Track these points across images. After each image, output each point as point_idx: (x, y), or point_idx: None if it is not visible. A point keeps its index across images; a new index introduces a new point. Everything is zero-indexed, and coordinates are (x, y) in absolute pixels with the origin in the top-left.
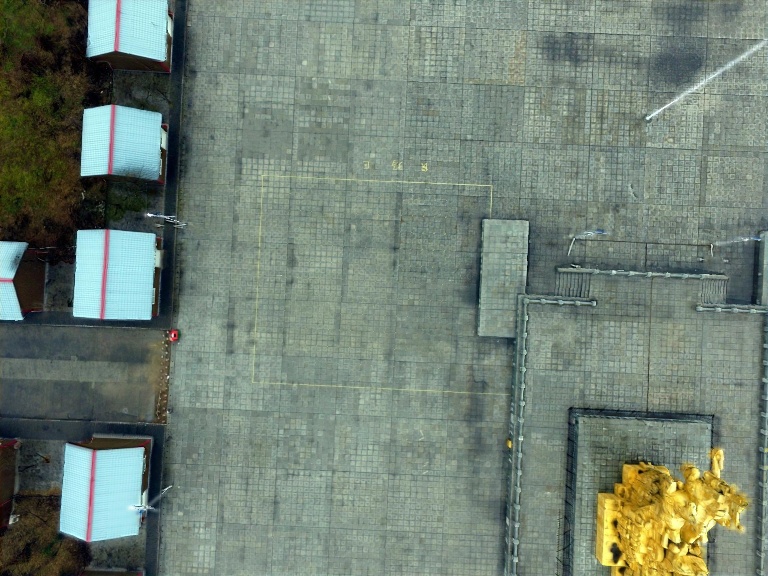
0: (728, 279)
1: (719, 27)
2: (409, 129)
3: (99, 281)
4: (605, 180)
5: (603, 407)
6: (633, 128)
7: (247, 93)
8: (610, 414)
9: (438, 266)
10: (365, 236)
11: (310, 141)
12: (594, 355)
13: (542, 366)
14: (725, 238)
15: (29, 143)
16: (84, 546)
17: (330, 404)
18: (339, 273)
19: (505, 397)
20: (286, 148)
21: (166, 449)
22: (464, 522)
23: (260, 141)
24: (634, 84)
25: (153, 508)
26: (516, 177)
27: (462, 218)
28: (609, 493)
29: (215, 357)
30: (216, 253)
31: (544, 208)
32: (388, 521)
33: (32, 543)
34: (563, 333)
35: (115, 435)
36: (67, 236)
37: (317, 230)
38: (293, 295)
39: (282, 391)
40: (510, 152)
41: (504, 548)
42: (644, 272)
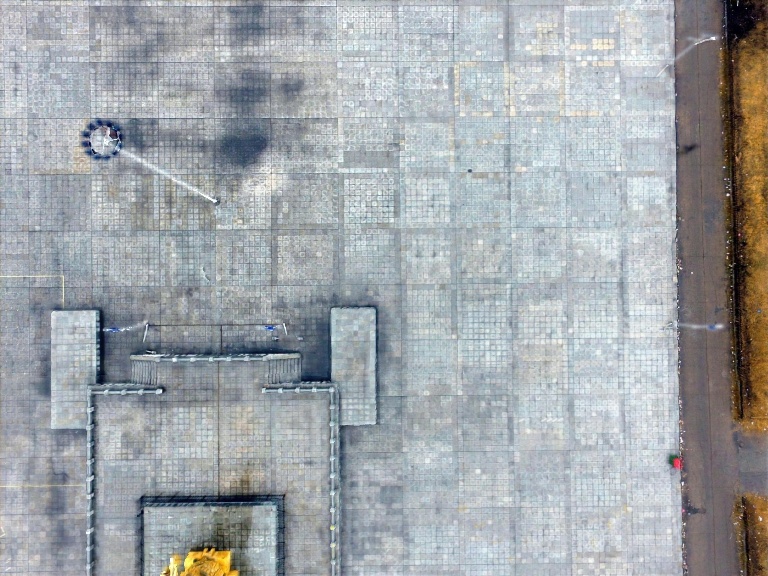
0: (302, 357)
1: (282, 107)
2: None
3: None
4: (177, 264)
5: (174, 494)
6: (202, 211)
7: None
8: (182, 500)
9: (12, 360)
10: None
11: None
12: (164, 442)
13: (112, 457)
14: (298, 316)
15: None
16: None
17: None
18: None
19: None
20: None
21: None
22: None
23: None
24: (201, 167)
25: None
26: (87, 266)
27: (34, 310)
28: None
29: None
30: None
31: (117, 296)
32: None
33: None
34: (132, 422)
35: None
36: None
37: None
38: None
39: None
40: (80, 241)
41: None
42: None
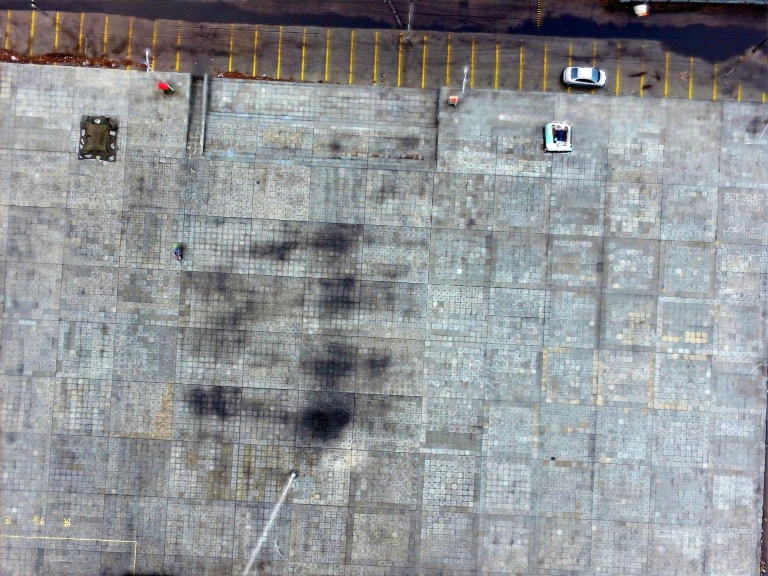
0: None
1: (366, 383)
2: (52, 483)
3: None
4: (251, 536)
5: None
6: (280, 483)
7: None
8: None
9: None
10: None
11: None
12: None
13: None
14: None
15: None
16: None
17: None
18: None
19: None
20: None
21: None
22: None
23: None
24: (281, 439)
25: None
26: (161, 533)
27: (105, 575)
28: None
29: None
30: None
31: (188, 565)
32: None
33: None
34: None
35: None
36: None
37: None
38: None
39: None
40: (155, 507)
41: None
42: None
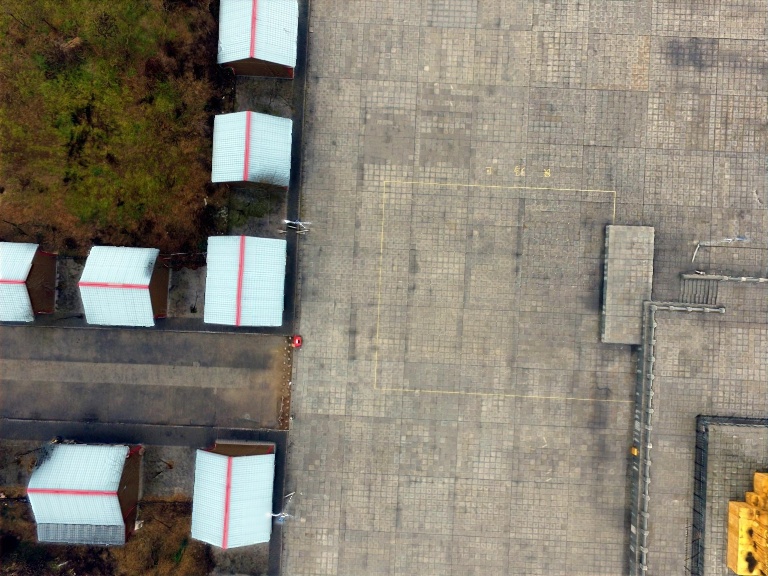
0: None
1: None
2: (532, 135)
3: (234, 287)
4: (730, 186)
5: (731, 415)
6: (758, 134)
7: (369, 99)
8: (738, 422)
9: (561, 272)
10: (487, 242)
11: (432, 147)
12: (722, 362)
13: (669, 373)
14: None
15: (152, 149)
16: (208, 552)
17: (452, 411)
18: (461, 279)
19: (629, 404)
20: (408, 154)
21: (288, 455)
22: (588, 530)
23: (382, 147)
24: (759, 89)
25: (291, 515)
26: (640, 183)
27: (585, 224)
28: (740, 501)
29: (337, 363)
30: (338, 259)
31: (668, 214)
32: (511, 528)
33: (158, 549)
34: (690, 340)
35: (237, 441)
36: (190, 242)
37: (439, 236)
38: (415, 301)
39: (404, 397)
40: (633, 158)
41: (629, 556)
42: None
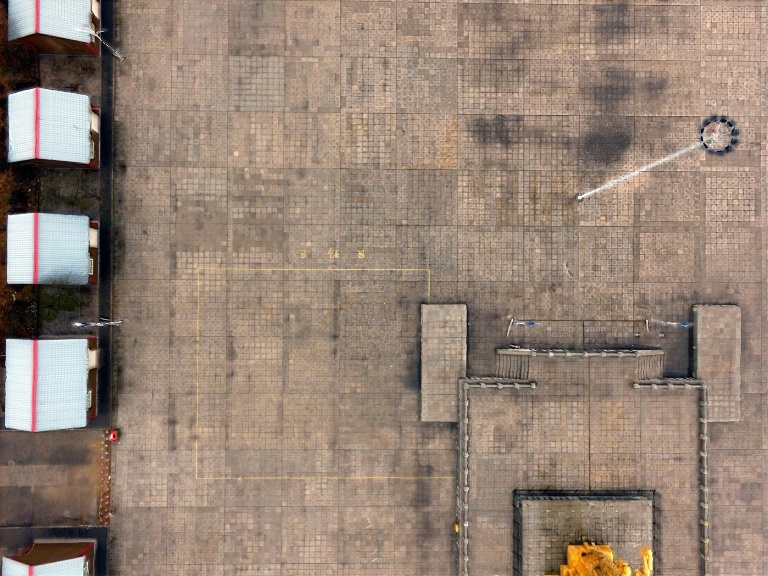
0: (664, 353)
1: (645, 105)
2: (344, 216)
3: (29, 393)
4: (540, 260)
5: (546, 488)
6: (566, 207)
7: (179, 186)
8: (554, 494)
9: (379, 352)
10: (304, 325)
11: (245, 232)
12: (536, 436)
13: (485, 450)
14: (660, 313)
15: None
16: None
17: (276, 496)
18: (280, 364)
19: (451, 480)
20: (221, 240)
21: (110, 551)
22: None
23: (194, 234)
24: (565, 164)
25: None
26: (453, 260)
27: (401, 303)
28: (555, 575)
29: (157, 455)
30: (154, 349)
31: (482, 290)
32: None
33: None
34: (504, 416)
35: (57, 540)
36: None
37: (256, 321)
38: (234, 388)
39: (227, 486)
40: (446, 236)
41: None
42: (581, 352)
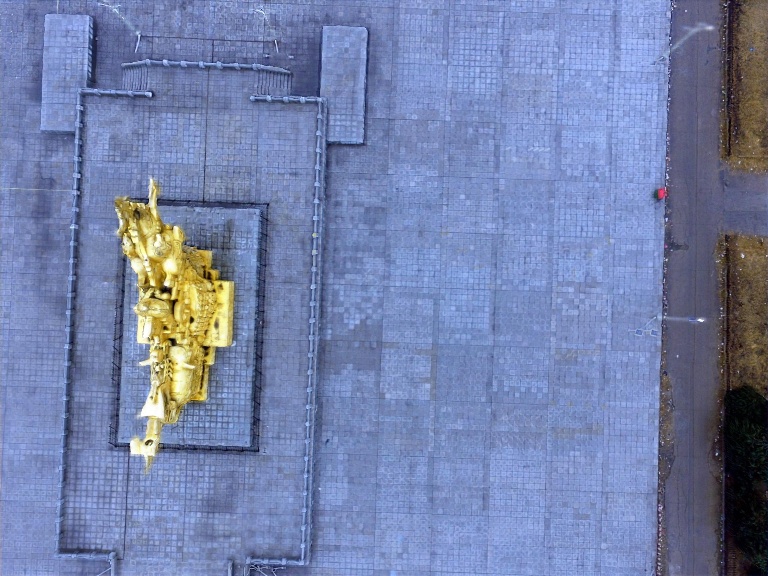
0: (292, 74)
1: None
2: None
3: None
4: None
5: (159, 197)
6: None
7: None
8: (166, 204)
9: (4, 63)
10: None
11: None
12: (151, 146)
13: (99, 158)
14: (290, 34)
15: None
16: None
17: None
18: None
19: None
20: None
21: None
22: (31, 318)
23: None
24: None
25: None
26: None
27: (28, 15)
28: None
29: None
30: None
31: (111, 5)
32: None
33: None
34: (120, 125)
35: None
36: None
37: None
38: None
39: None
40: None
41: None
42: None
